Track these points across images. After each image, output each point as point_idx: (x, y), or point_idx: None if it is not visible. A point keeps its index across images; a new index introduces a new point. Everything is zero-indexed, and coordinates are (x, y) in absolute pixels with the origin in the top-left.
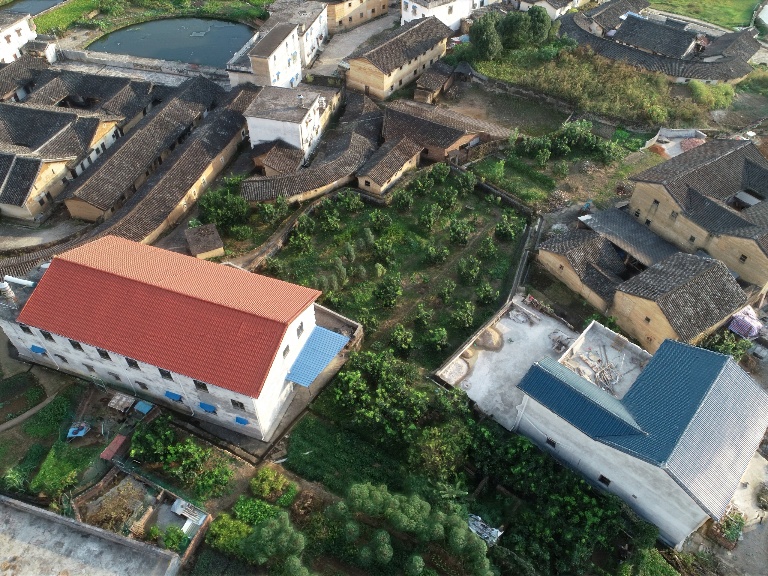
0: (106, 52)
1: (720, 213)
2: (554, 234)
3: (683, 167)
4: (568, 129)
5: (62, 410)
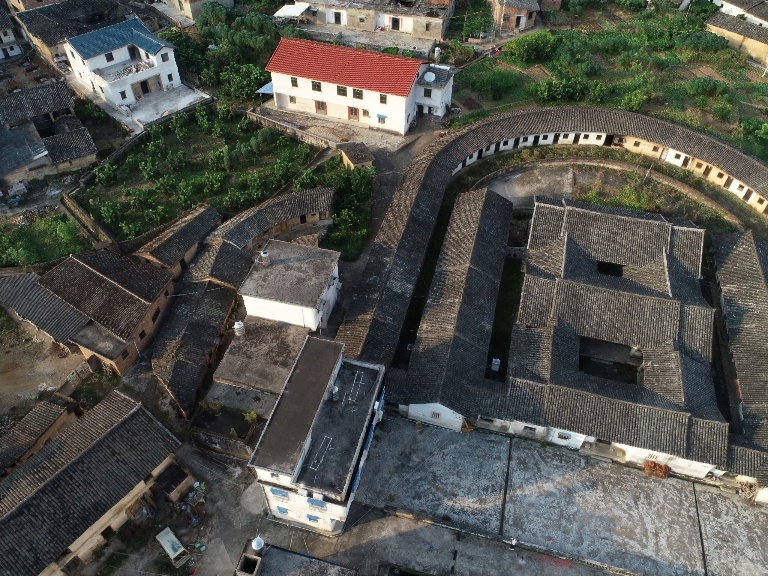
0: None
1: None
2: (67, 177)
3: None
4: None
5: None
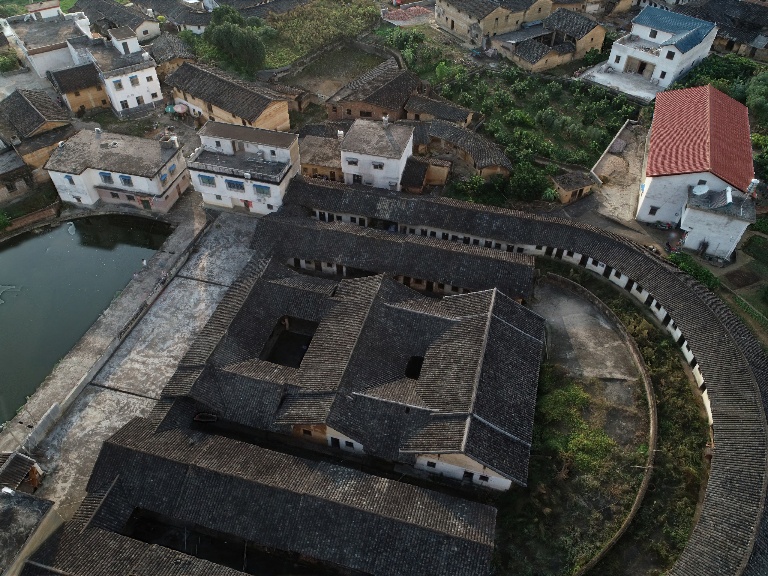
0: (26, 397)
1: (516, 1)
2: (507, 64)
3: (477, 0)
4: (397, 38)
5: (764, 220)
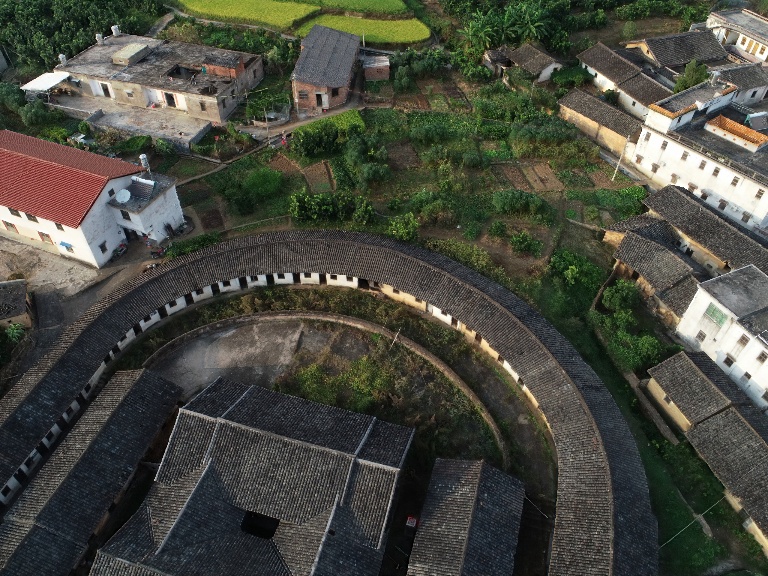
0: None
1: None
2: None
3: None
4: None
5: None
